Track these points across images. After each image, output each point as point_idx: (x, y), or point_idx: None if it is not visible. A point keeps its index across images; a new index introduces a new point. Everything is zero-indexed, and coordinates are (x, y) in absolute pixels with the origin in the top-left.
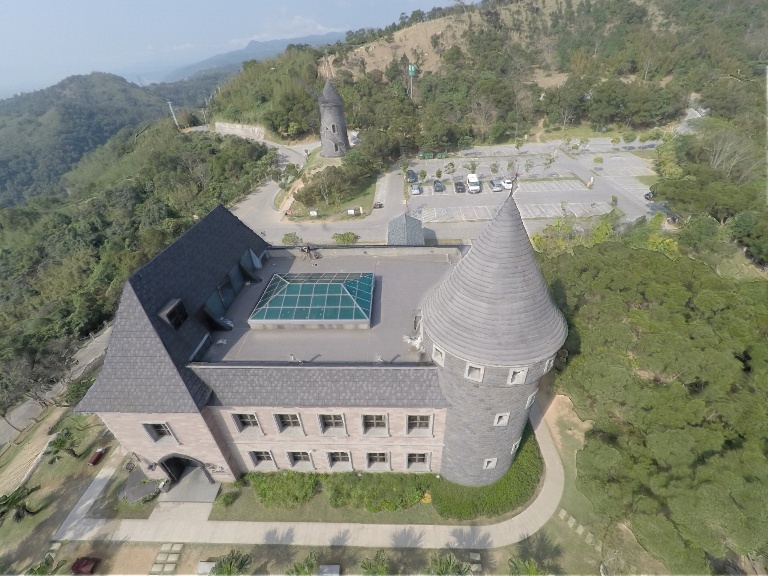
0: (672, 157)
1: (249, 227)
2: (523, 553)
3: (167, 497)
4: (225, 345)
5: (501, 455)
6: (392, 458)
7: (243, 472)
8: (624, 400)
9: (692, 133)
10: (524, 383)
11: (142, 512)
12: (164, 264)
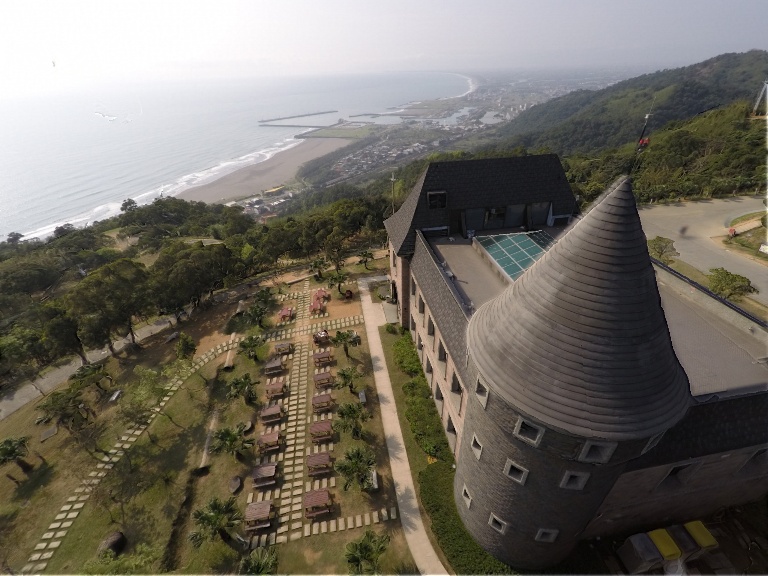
0: None
1: (665, 226)
2: (408, 573)
3: (384, 304)
4: (450, 241)
5: (476, 502)
6: (444, 406)
7: (409, 328)
8: None
9: None
10: (486, 409)
11: (375, 299)
12: (460, 168)
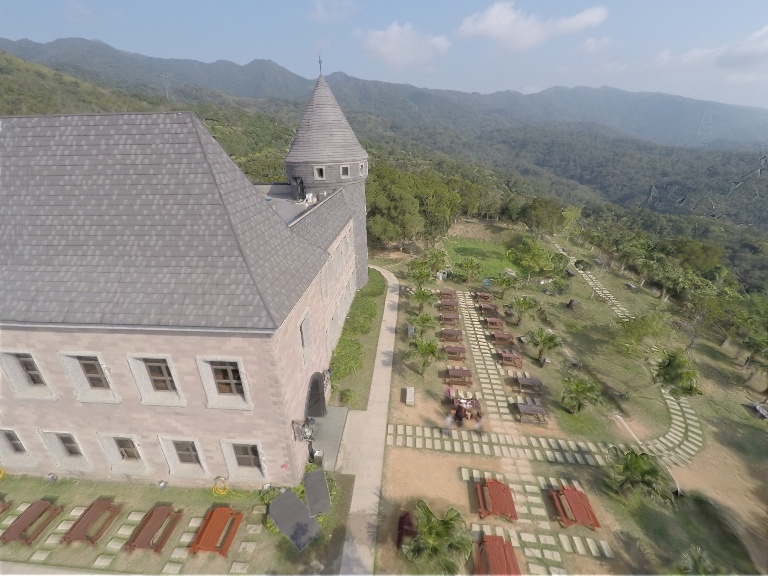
0: None
1: None
2: (401, 278)
3: (331, 458)
4: None
5: None
6: None
7: None
8: None
9: None
10: None
11: (344, 488)
12: None
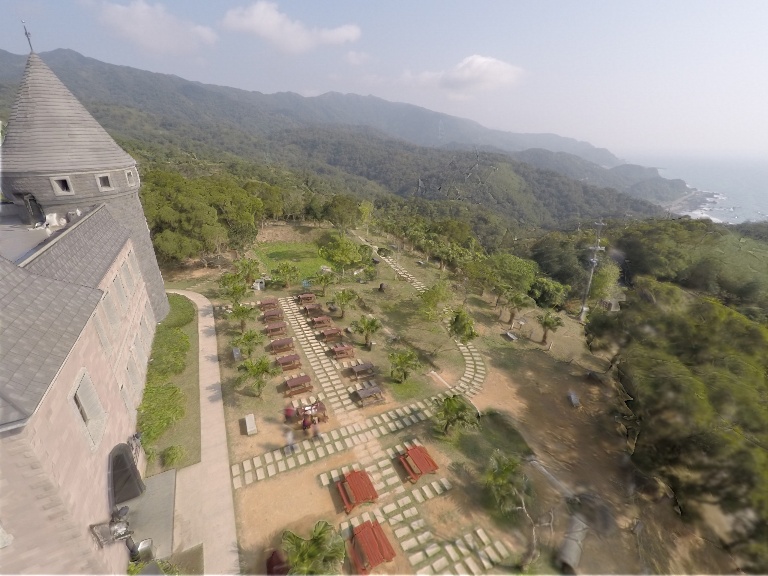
0: None
1: None
2: (213, 297)
3: (165, 540)
4: None
5: None
6: None
7: None
8: None
9: None
10: None
11: (191, 566)
12: None
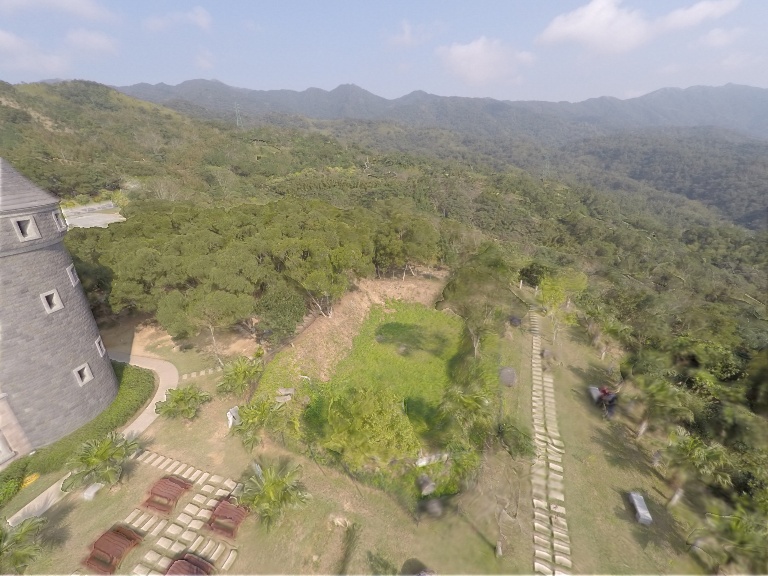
0: (127, 201)
1: None
2: None
3: None
4: None
5: (89, 358)
6: None
7: None
8: (162, 269)
9: (132, 186)
10: (41, 238)
11: None
12: None
